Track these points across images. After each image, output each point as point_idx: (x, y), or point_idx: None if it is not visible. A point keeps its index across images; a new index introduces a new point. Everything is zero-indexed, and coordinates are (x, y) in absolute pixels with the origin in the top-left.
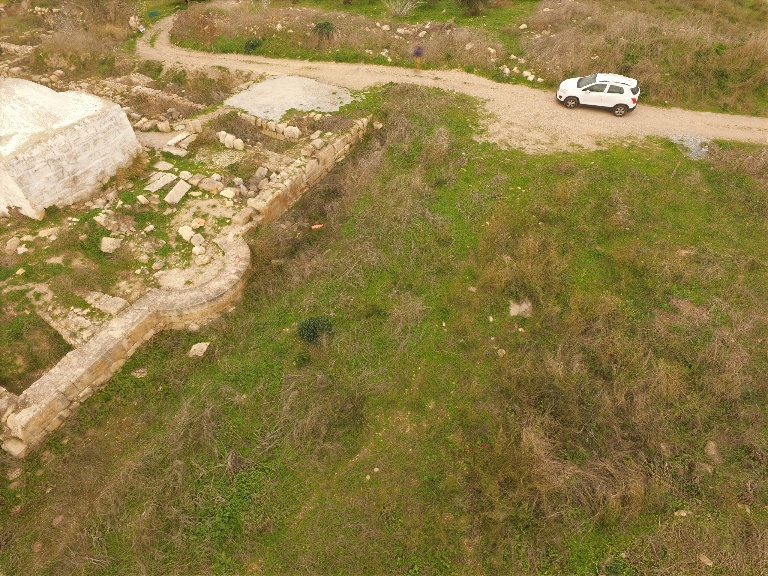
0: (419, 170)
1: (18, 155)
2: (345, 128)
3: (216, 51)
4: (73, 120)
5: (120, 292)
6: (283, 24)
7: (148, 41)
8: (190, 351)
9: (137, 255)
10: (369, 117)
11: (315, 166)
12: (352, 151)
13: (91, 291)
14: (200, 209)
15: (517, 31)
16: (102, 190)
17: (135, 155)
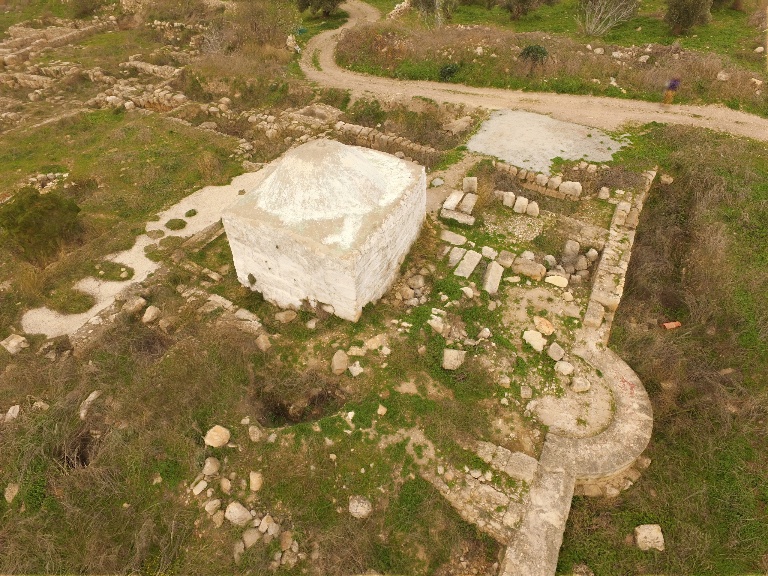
0: None
1: (360, 248)
2: (639, 185)
3: (402, 77)
4: (395, 193)
5: (504, 438)
6: (484, 47)
7: (311, 63)
8: (640, 540)
9: (497, 377)
10: (655, 169)
11: None
12: (642, 212)
13: (478, 440)
14: (531, 303)
15: (757, 55)
16: (401, 274)
17: (422, 225)
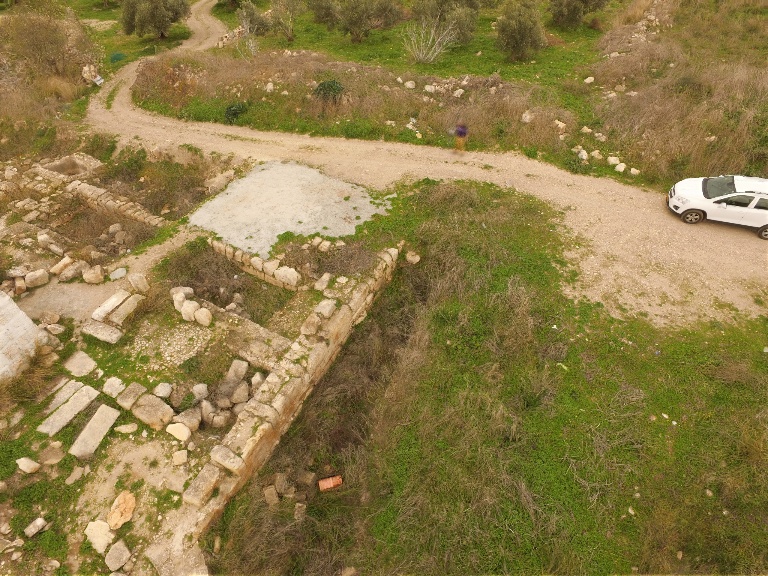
0: (493, 374)
1: None
2: (366, 270)
3: (188, 118)
4: None
5: None
6: (275, 83)
7: (104, 99)
8: None
9: None
10: (400, 245)
11: (323, 352)
12: (376, 301)
13: None
14: (130, 469)
15: (583, 87)
16: None
17: (33, 351)
